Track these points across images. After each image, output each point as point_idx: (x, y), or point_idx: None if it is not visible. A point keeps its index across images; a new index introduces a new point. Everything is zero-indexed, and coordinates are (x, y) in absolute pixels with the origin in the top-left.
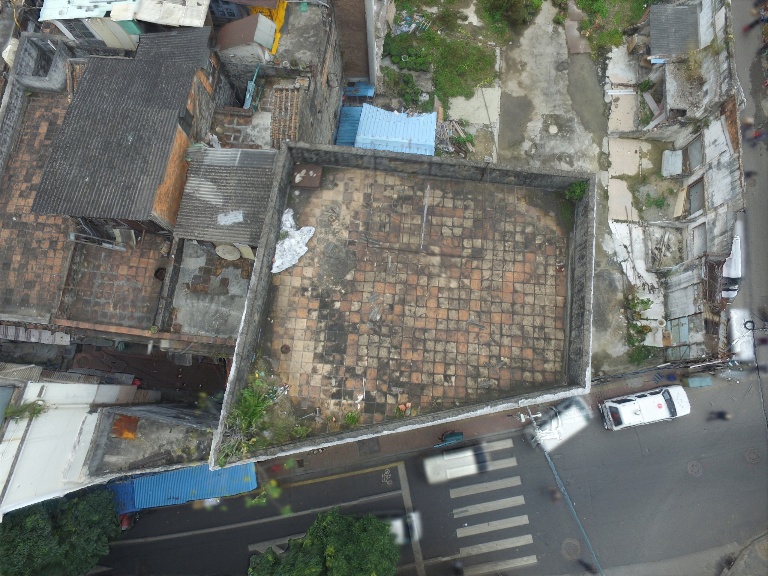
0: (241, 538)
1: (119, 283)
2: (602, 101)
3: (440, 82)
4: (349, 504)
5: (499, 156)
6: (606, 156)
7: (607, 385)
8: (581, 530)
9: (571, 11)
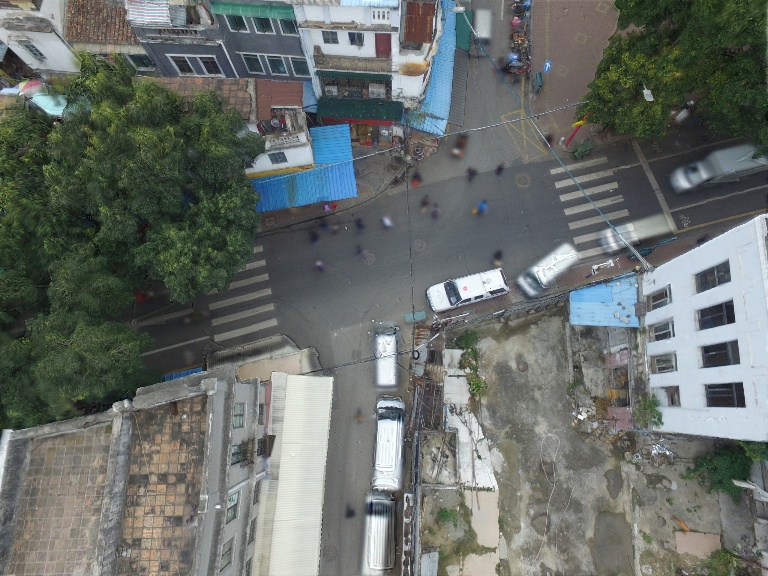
0: None
1: None
2: None
3: None
4: (714, 198)
5: (634, 575)
6: None
7: (496, 310)
8: None
9: None
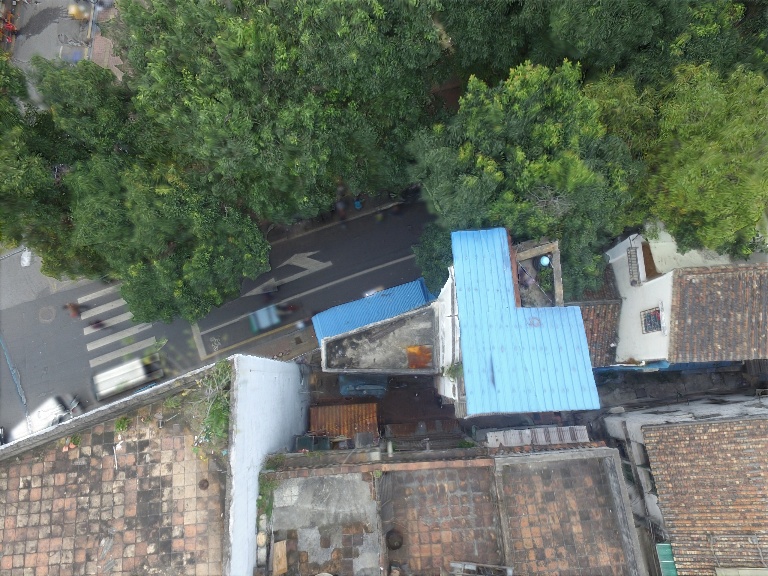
0: (340, 269)
1: (446, 519)
2: None
3: None
4: (248, 314)
5: None
6: None
7: None
8: (2, 340)
9: None
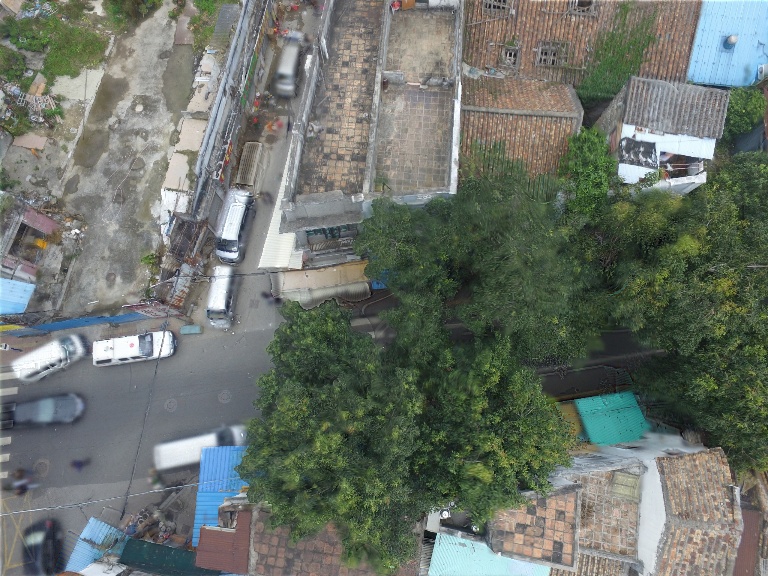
0: None
1: None
2: (190, 86)
3: (47, 61)
4: None
5: (84, 128)
6: (178, 133)
7: (118, 330)
8: None
9: (187, 8)
